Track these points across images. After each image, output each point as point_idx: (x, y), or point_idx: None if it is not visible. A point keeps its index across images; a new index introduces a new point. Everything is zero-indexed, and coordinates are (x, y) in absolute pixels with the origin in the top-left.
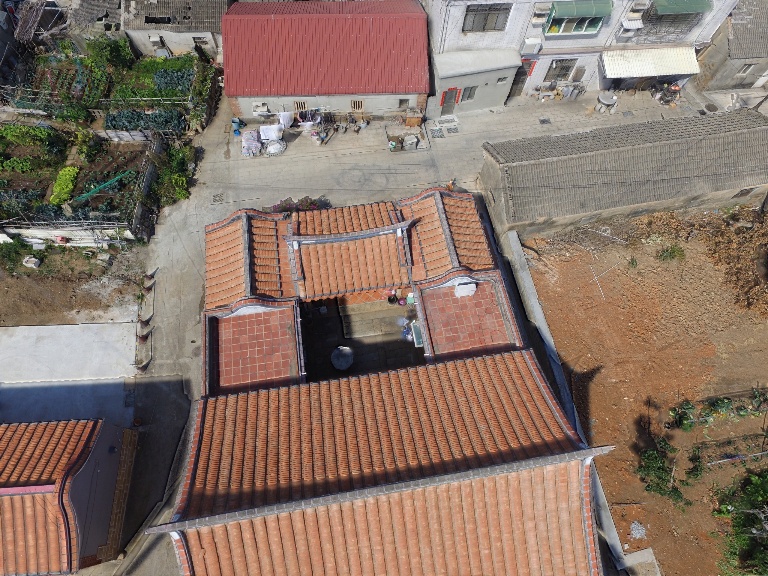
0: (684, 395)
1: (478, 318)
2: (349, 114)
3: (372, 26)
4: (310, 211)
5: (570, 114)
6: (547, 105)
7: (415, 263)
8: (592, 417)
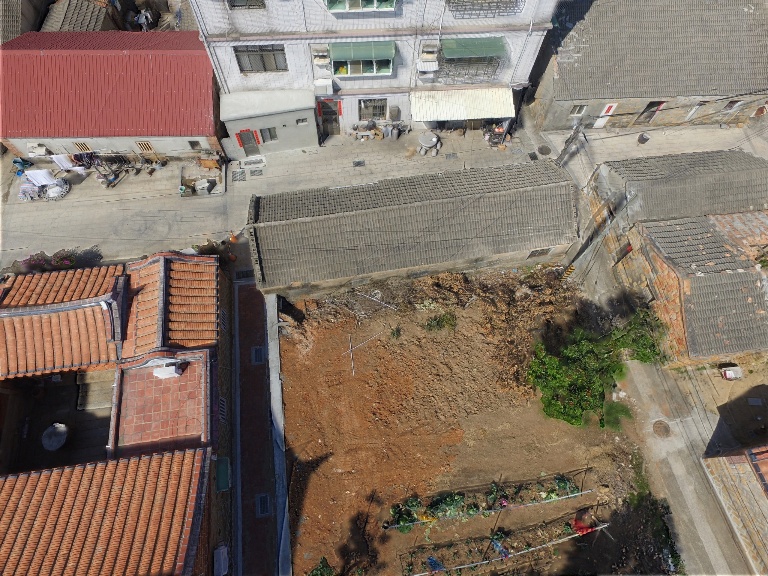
0: (414, 489)
1: (178, 404)
2: (141, 155)
3: (151, 63)
4: (30, 274)
5: (388, 156)
6: (366, 145)
7: (128, 337)
8: (303, 514)
